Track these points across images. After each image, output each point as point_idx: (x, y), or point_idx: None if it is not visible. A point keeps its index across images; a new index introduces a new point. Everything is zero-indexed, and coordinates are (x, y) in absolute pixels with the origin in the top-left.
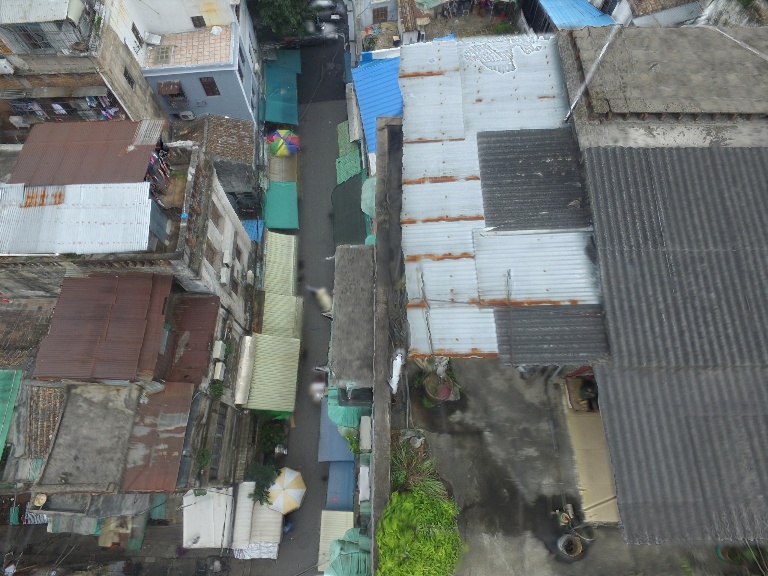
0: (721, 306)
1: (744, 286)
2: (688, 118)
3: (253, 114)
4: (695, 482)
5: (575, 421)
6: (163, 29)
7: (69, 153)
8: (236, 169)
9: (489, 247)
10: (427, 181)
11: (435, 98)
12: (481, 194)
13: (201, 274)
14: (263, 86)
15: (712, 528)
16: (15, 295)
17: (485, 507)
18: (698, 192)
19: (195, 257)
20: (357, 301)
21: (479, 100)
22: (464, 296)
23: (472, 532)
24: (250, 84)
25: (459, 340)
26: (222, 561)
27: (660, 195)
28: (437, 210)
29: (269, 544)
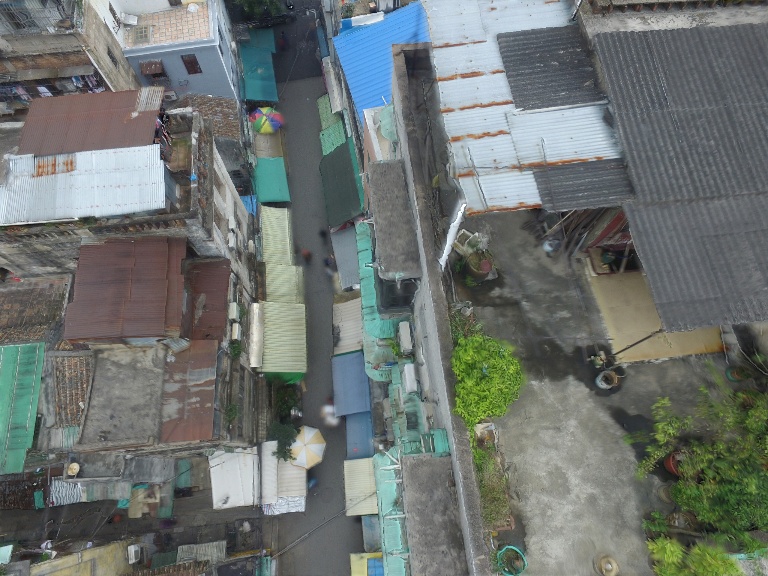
0: (719, 150)
1: (736, 133)
2: (676, 8)
3: (234, 92)
4: (713, 283)
5: (598, 286)
6: (139, 9)
7: (73, 123)
8: (224, 146)
9: (522, 124)
10: (459, 77)
11: (455, 9)
12: (508, 84)
13: (213, 235)
14: (240, 65)
15: (730, 316)
16: (25, 274)
17: (531, 361)
18: (691, 63)
19: (207, 217)
20: (394, 207)
21: (494, 8)
22: (506, 164)
23: (523, 381)
24: (229, 62)
25: (508, 197)
26: (250, 522)
27: (661, 67)
28: (472, 99)
29: (296, 498)
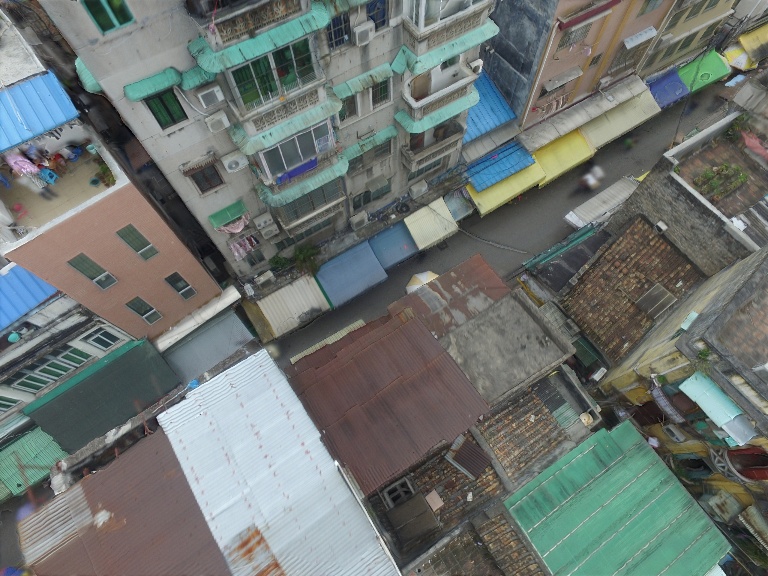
0: None
1: None
2: None
3: None
4: None
5: None
6: None
7: None
8: None
9: None
10: None
11: None
12: None
13: None
14: None
15: None
16: None
17: None
18: None
19: None
20: None
21: None
22: None
23: None
24: None
25: None
26: None
27: None
28: None
29: None
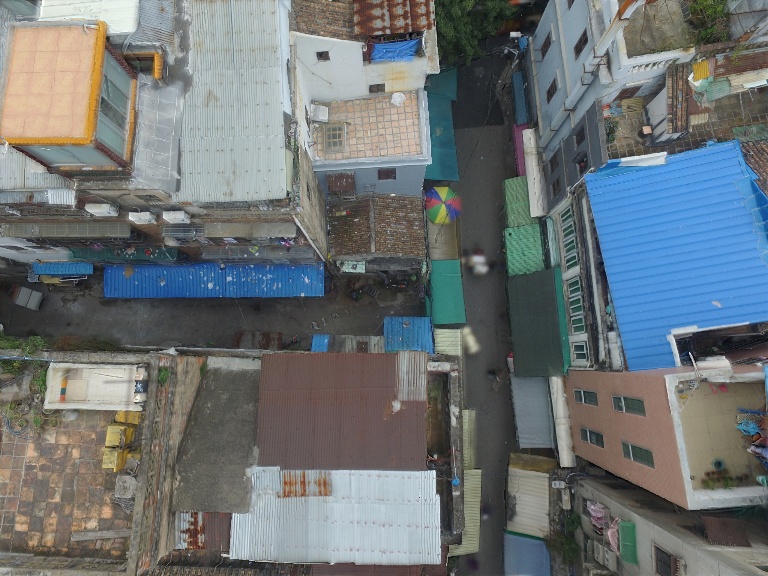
0: None
1: None
2: None
3: None
4: None
5: None
6: (330, 96)
7: (320, 411)
8: (403, 260)
9: None
10: None
11: None
12: None
13: None
14: None
15: None
16: None
17: None
18: None
19: None
20: None
21: None
22: None
23: None
24: None
25: None
26: None
27: None
28: None
29: None
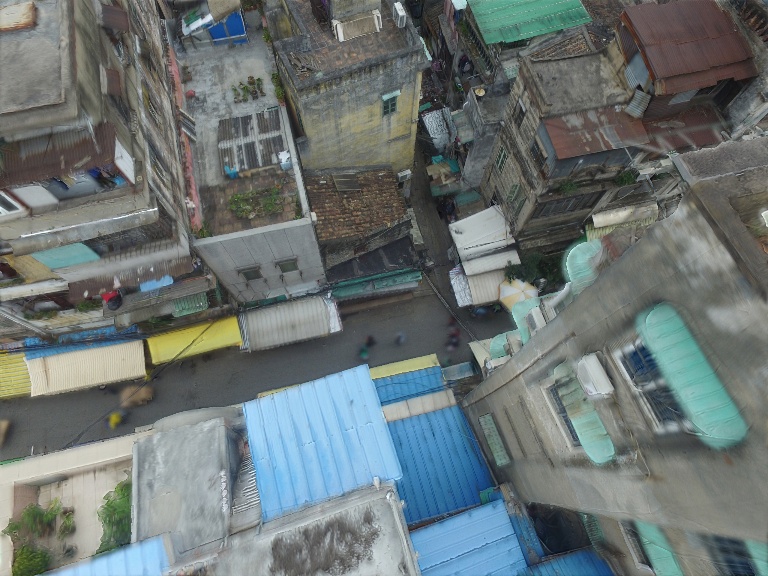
0: None
1: None
2: None
3: None
4: None
5: None
6: None
7: None
8: None
9: None
10: None
11: None
12: None
13: None
14: None
15: None
16: None
17: None
18: None
19: None
20: None
21: None
22: None
23: None
24: None
25: None
26: None
27: None
28: None
29: (469, 296)
